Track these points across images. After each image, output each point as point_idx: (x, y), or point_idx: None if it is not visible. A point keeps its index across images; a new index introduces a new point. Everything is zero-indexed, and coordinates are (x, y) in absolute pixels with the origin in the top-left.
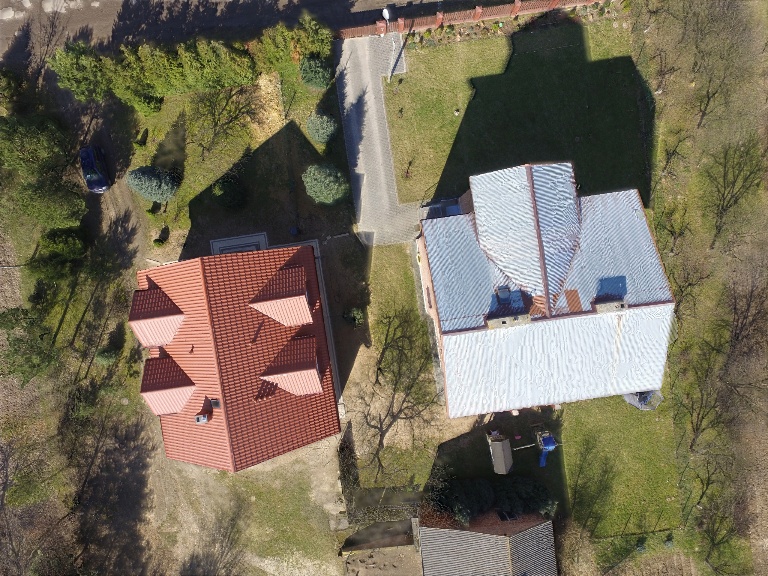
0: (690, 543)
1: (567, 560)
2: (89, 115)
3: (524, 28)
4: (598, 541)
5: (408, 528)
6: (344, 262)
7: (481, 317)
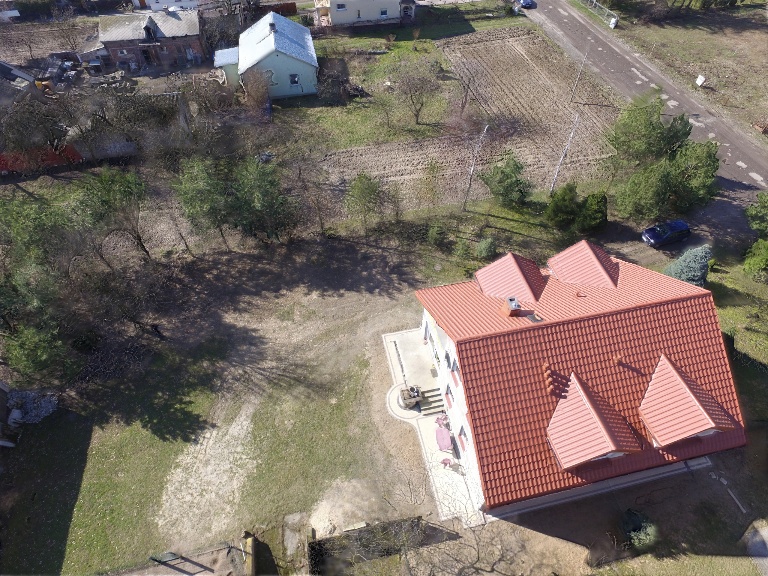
0: None
1: None
2: (710, 230)
3: None
4: None
5: None
6: (701, 508)
7: None
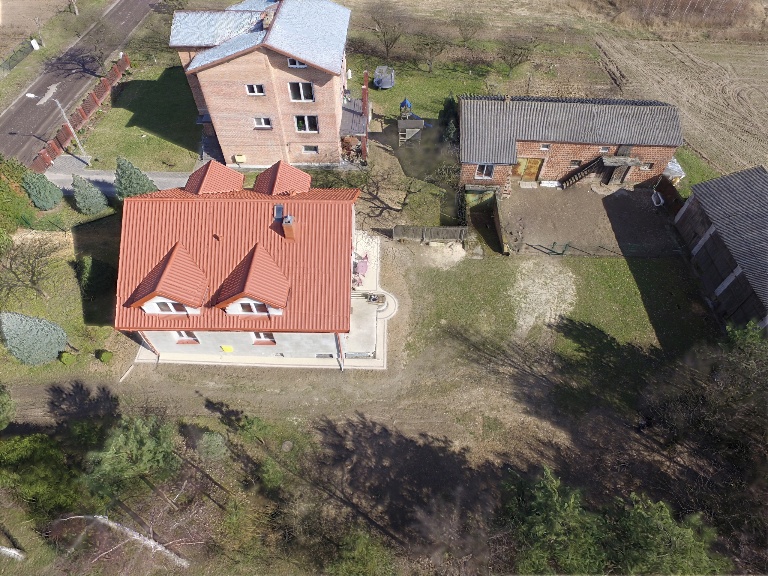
0: (496, 80)
1: None
2: None
3: (112, 101)
4: None
5: (488, 217)
6: None
7: (261, 32)
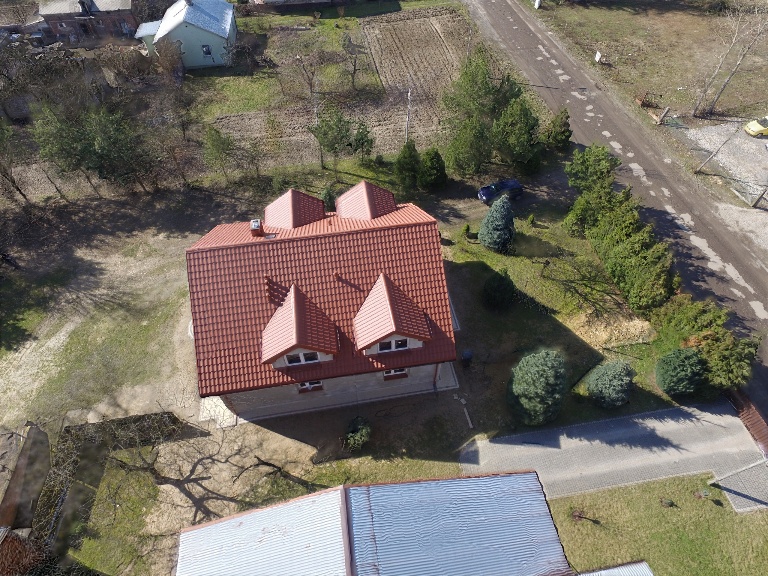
0: None
1: None
2: (548, 191)
3: None
4: None
5: None
6: (432, 422)
7: (376, 575)
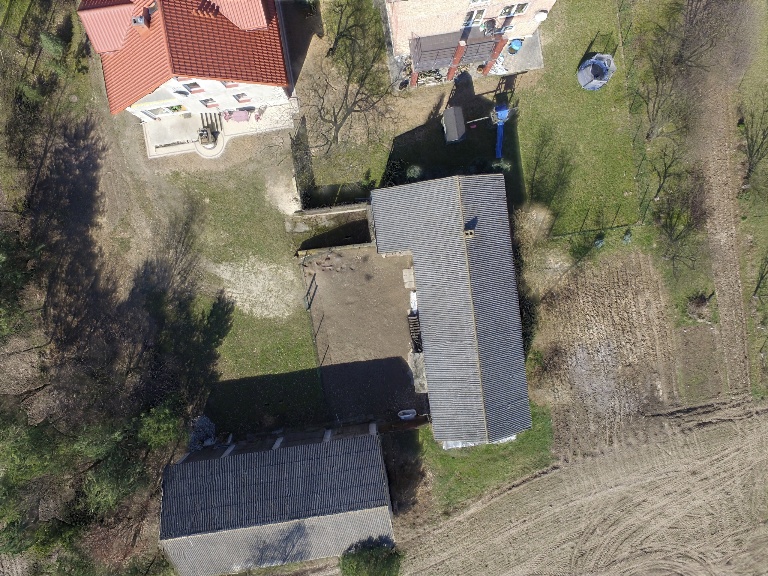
0: (648, 239)
1: (521, 229)
2: None
3: None
4: (556, 239)
5: (366, 238)
6: None
7: None
